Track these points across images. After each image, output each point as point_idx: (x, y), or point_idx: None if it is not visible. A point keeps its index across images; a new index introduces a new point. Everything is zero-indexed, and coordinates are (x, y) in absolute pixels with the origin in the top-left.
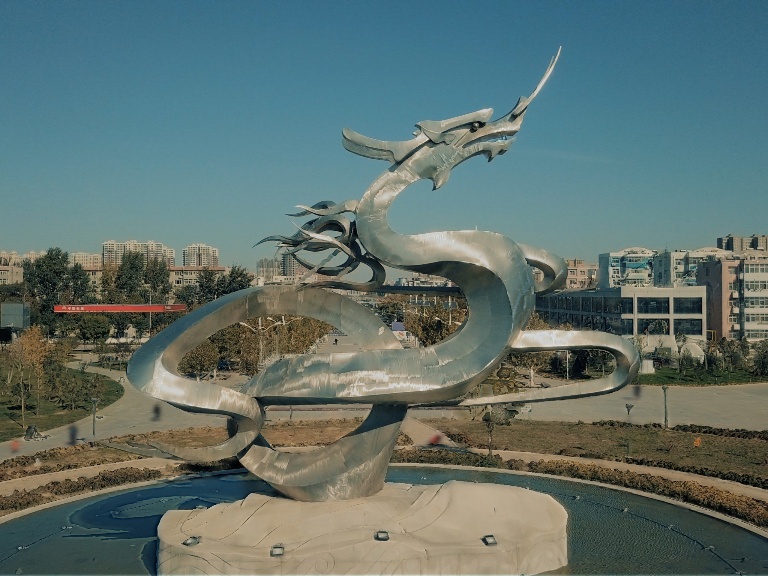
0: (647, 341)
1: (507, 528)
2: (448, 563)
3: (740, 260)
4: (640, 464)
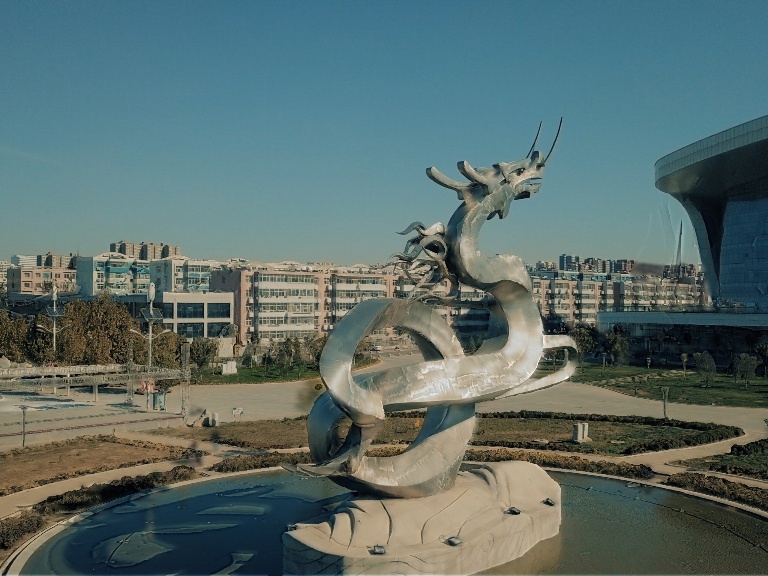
0: (223, 344)
1: (542, 492)
2: (537, 525)
3: (248, 270)
4: None
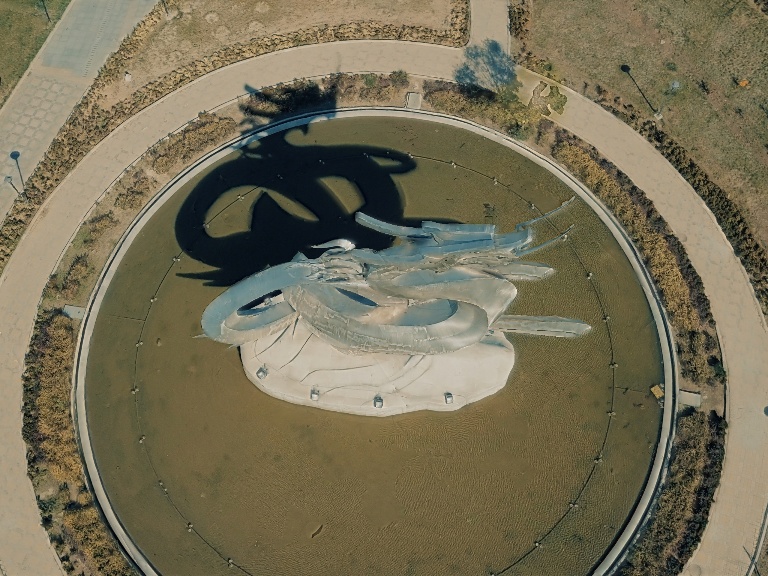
0: None
1: (465, 383)
2: None
3: None
4: (659, 141)
